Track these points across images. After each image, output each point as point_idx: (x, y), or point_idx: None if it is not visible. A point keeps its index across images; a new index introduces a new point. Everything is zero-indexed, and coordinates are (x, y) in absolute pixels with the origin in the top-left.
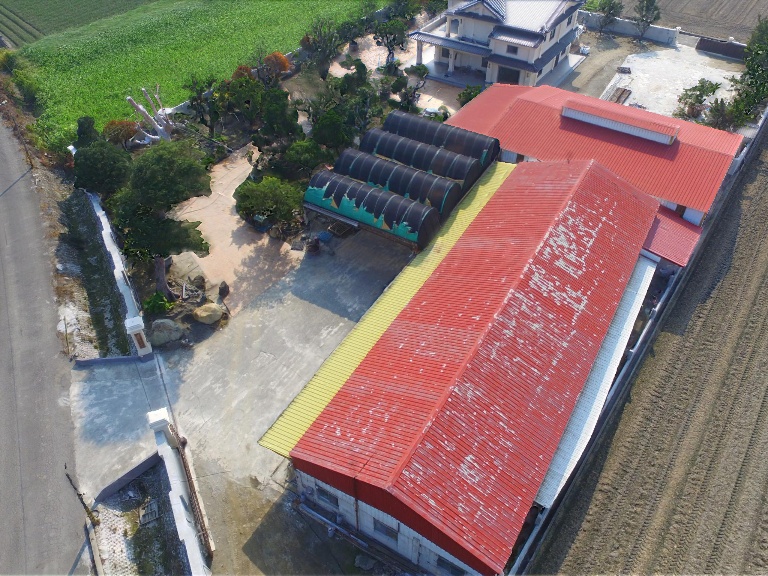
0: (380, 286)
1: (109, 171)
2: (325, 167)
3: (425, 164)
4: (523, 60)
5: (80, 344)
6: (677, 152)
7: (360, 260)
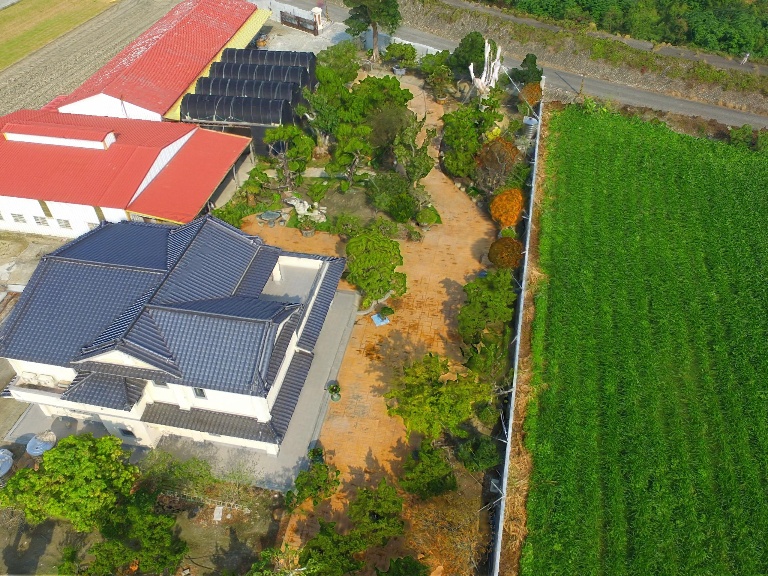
0: None
1: None
2: None
3: None
4: None
5: None
6: None
7: None
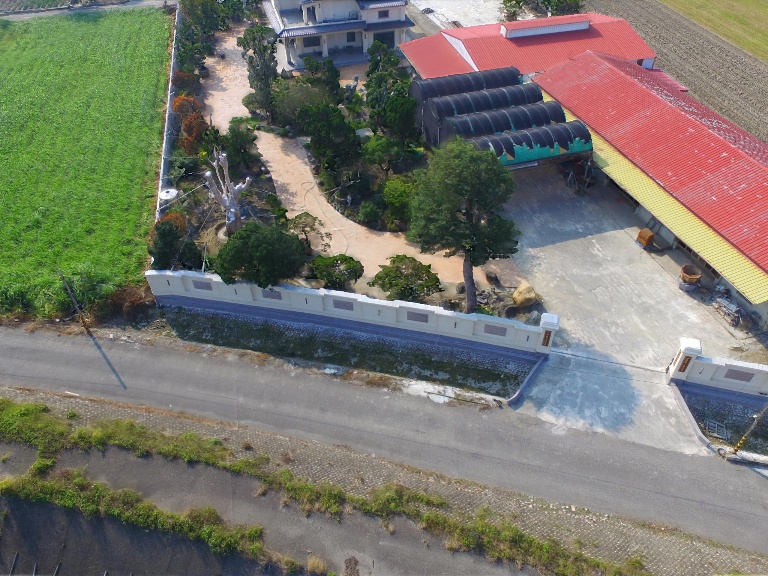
0: (566, 206)
1: (290, 247)
2: (374, 164)
3: (505, 103)
4: (395, 20)
5: (477, 395)
6: (598, 31)
7: (524, 201)
